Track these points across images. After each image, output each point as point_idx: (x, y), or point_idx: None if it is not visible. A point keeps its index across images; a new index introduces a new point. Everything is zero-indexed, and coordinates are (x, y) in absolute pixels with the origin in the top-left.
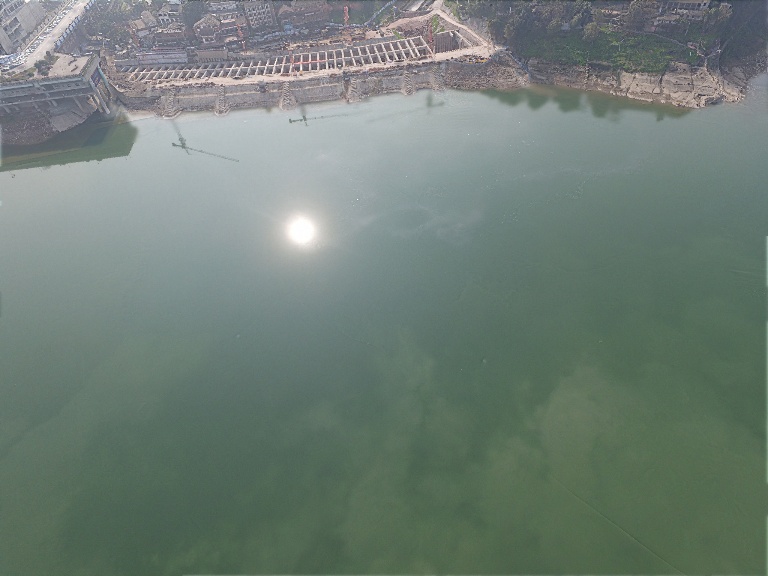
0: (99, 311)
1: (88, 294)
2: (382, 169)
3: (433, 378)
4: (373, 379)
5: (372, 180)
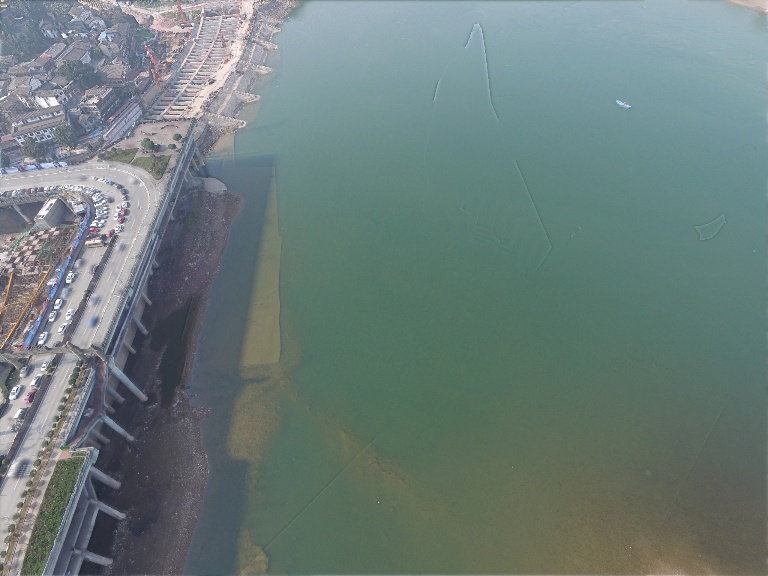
0: (495, 104)
1: None
2: (372, 36)
3: (529, 19)
4: (529, 32)
5: (381, 39)
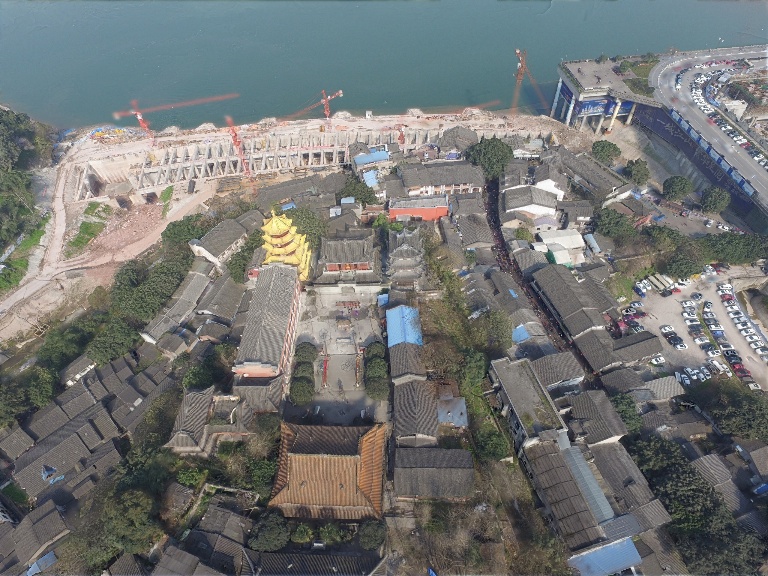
0: (430, 8)
1: (441, 11)
2: (266, 61)
3: None
4: None
5: (276, 57)
